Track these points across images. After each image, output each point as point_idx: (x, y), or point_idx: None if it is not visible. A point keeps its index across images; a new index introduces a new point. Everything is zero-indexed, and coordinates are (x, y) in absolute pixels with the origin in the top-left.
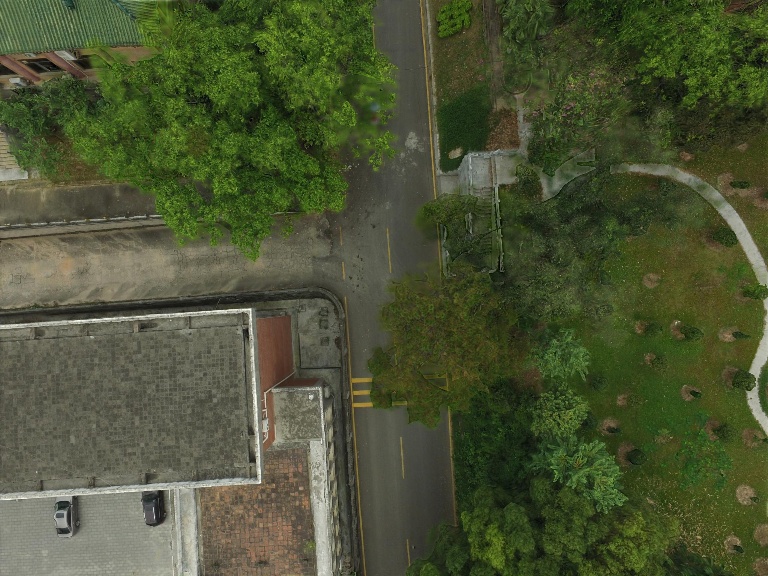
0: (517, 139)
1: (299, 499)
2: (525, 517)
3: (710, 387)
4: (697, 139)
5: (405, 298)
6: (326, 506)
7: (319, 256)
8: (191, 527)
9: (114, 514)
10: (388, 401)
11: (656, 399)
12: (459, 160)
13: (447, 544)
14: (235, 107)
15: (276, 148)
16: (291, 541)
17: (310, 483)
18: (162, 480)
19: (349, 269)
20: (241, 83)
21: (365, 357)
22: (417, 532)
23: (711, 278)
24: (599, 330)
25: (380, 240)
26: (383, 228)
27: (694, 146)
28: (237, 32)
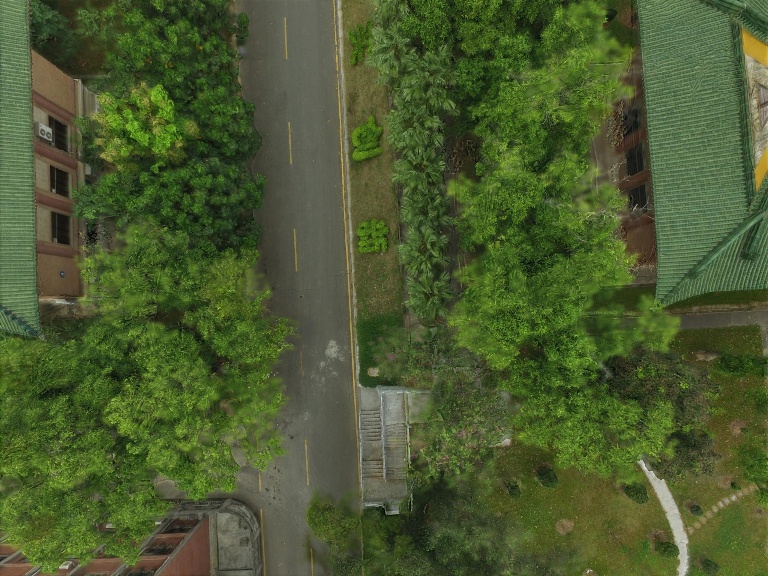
0: (431, 376)
1: None
2: None
3: None
4: None
5: None
6: None
7: None
8: None
9: None
10: None
11: None
12: (376, 381)
13: None
14: None
15: (136, 503)
16: None
17: None
18: None
19: (266, 481)
20: None
21: (281, 571)
22: None
23: (624, 526)
24: None
25: (298, 452)
26: (301, 439)
27: None
28: (95, 386)
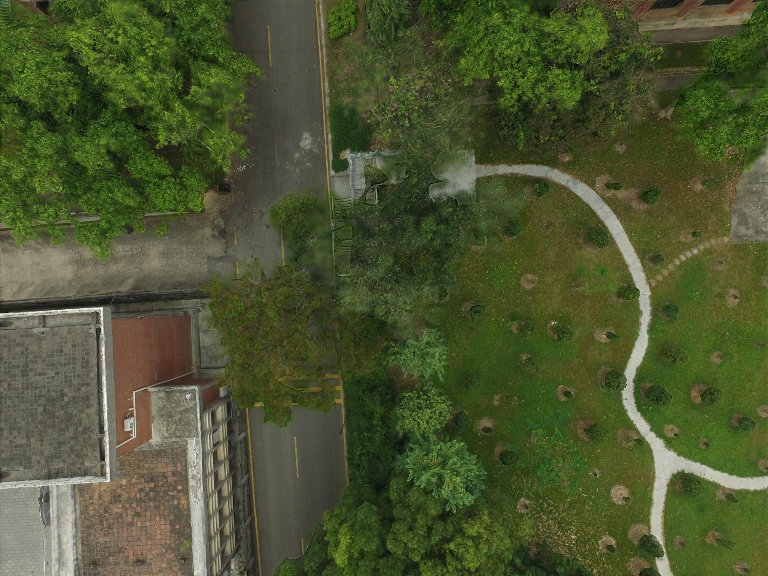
0: (398, 140)
1: (177, 498)
2: (374, 516)
3: (586, 387)
4: (550, 140)
5: (219, 297)
6: (201, 505)
7: (214, 256)
8: (68, 526)
9: (13, 513)
10: (250, 400)
11: (532, 399)
12: None
13: (315, 543)
14: (57, 107)
15: (100, 148)
16: (169, 540)
17: (189, 482)
18: (14, 478)
19: (243, 269)
20: (53, 83)
21: None
22: (312, 531)
23: (587, 279)
24: (476, 330)
25: (274, 240)
26: (277, 228)
27: (548, 147)
28: (59, 32)
